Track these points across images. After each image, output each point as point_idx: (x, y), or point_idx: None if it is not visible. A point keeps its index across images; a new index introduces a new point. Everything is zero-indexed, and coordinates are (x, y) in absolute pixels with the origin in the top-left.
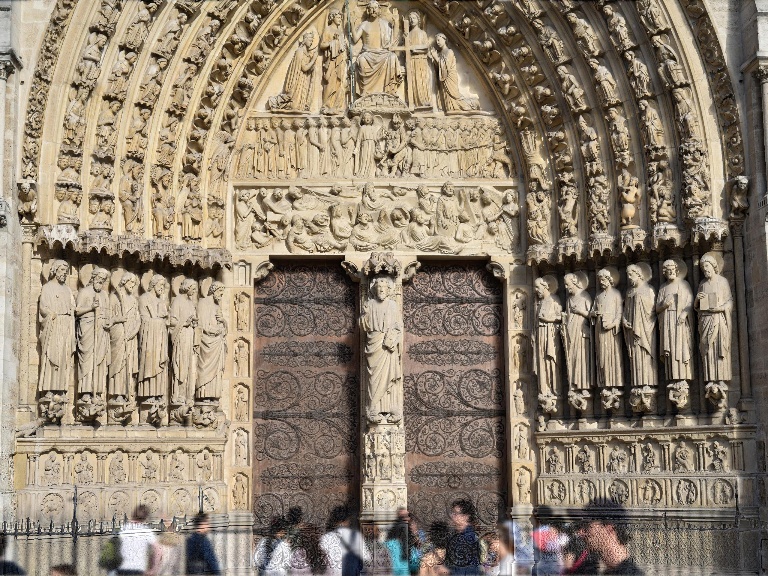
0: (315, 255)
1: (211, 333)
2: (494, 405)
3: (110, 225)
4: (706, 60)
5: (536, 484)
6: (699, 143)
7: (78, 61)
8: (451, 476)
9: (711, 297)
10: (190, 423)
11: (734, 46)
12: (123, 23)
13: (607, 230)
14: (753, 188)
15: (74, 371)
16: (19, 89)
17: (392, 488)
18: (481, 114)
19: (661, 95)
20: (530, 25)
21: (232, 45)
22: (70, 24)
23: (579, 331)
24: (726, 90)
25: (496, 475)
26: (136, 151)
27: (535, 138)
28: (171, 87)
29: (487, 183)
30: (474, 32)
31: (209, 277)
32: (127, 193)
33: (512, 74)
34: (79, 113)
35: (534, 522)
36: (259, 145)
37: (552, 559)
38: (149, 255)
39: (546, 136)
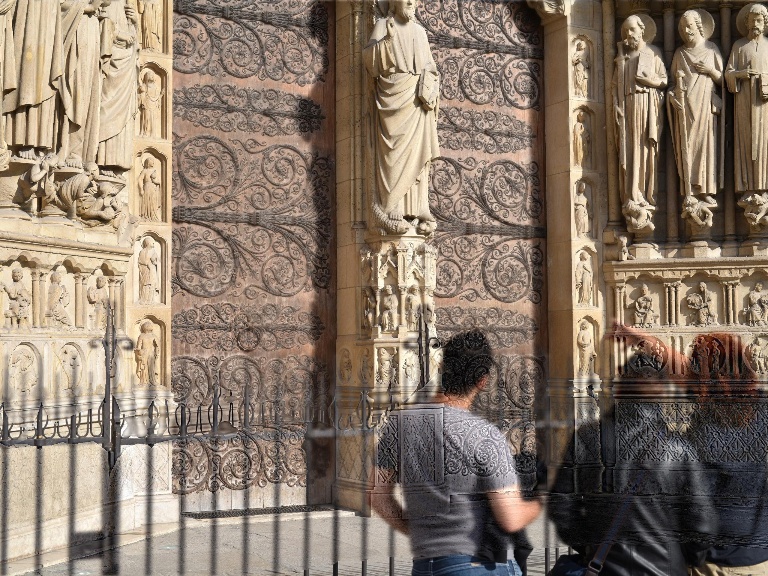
0: None
1: (119, 39)
2: (529, 219)
3: None
4: None
5: (608, 344)
6: None
7: None
8: (471, 330)
9: None
10: (74, 214)
11: None
12: None
13: None
14: None
15: None
16: None
17: None
18: None
19: None
20: None
21: None
22: None
23: (708, 102)
24: None
25: (532, 330)
26: None
27: None
28: None
29: None
30: None
31: None
32: None
33: None
34: None
35: (601, 403)
36: None
37: (640, 460)
38: None
39: None
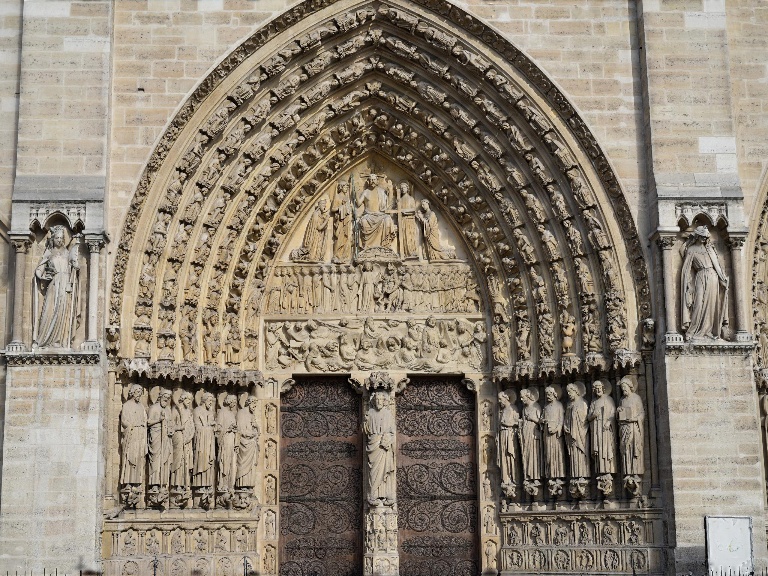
0: (328, 374)
1: (247, 436)
2: (468, 491)
3: (173, 357)
4: (623, 229)
5: (500, 554)
6: (618, 292)
7: (150, 234)
8: (434, 547)
9: (628, 410)
10: (231, 506)
11: (644, 219)
12: (183, 203)
13: (552, 356)
14: (658, 328)
15: (146, 468)
16: (107, 258)
17: (387, 557)
18: (457, 262)
19: (591, 254)
20: (493, 196)
21: (264, 213)
22: (144, 207)
23: (532, 434)
24: (638, 253)
25: (470, 546)
26: (192, 299)
27: (498, 282)
28: (218, 248)
29: (462, 316)
30: (451, 199)
31: (246, 392)
32: (185, 331)
33: (480, 232)
34: (151, 274)
35: None
36: (284, 288)
37: None
38: (201, 378)
39: (507, 281)
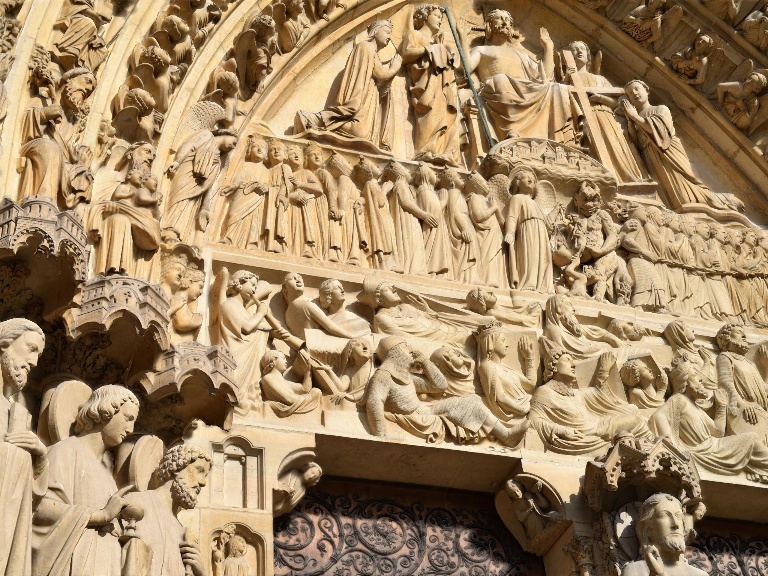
0: (438, 452)
1: None
2: None
3: None
4: None
5: None
6: None
7: None
8: None
9: None
10: None
11: None
12: None
13: None
14: None
15: None
16: None
17: None
18: (746, 224)
19: None
20: None
21: None
22: None
23: None
24: None
25: None
26: None
27: None
28: None
29: None
30: (712, 73)
31: (155, 436)
32: None
33: None
34: None
35: None
36: (279, 188)
37: None
38: (5, 232)
39: None
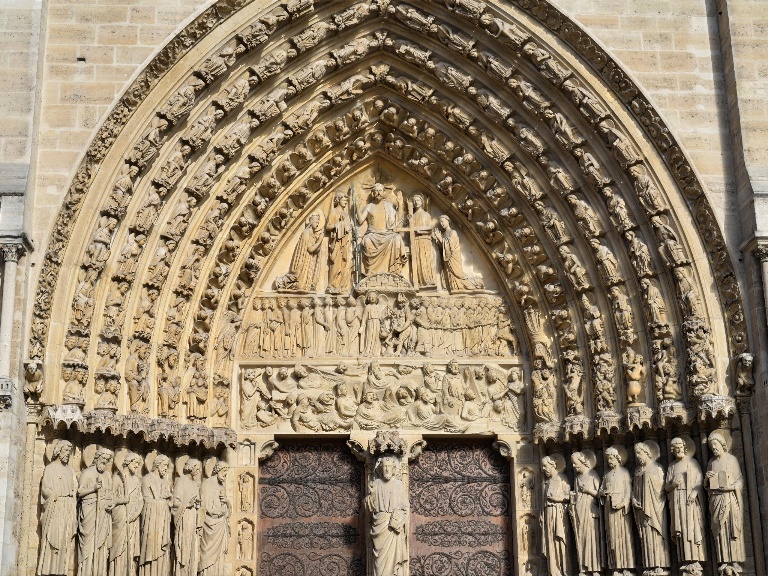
0: (320, 434)
1: (214, 514)
2: None
3: (115, 405)
4: (705, 240)
5: None
6: (702, 321)
7: (88, 243)
8: None
9: (721, 476)
10: None
11: (732, 226)
12: (134, 207)
13: (613, 408)
14: (758, 365)
15: (74, 554)
16: (30, 271)
17: None
18: (485, 293)
19: (662, 274)
20: (531, 207)
21: (240, 227)
22: (82, 208)
23: (588, 511)
24: (726, 269)
25: None
26: (143, 331)
27: (539, 316)
28: (179, 268)
29: (492, 361)
30: (477, 213)
31: (213, 457)
32: (133, 373)
33: (515, 254)
34: (88, 294)
35: None
36: (265, 324)
37: None
38: (153, 435)
39: (550, 314)
